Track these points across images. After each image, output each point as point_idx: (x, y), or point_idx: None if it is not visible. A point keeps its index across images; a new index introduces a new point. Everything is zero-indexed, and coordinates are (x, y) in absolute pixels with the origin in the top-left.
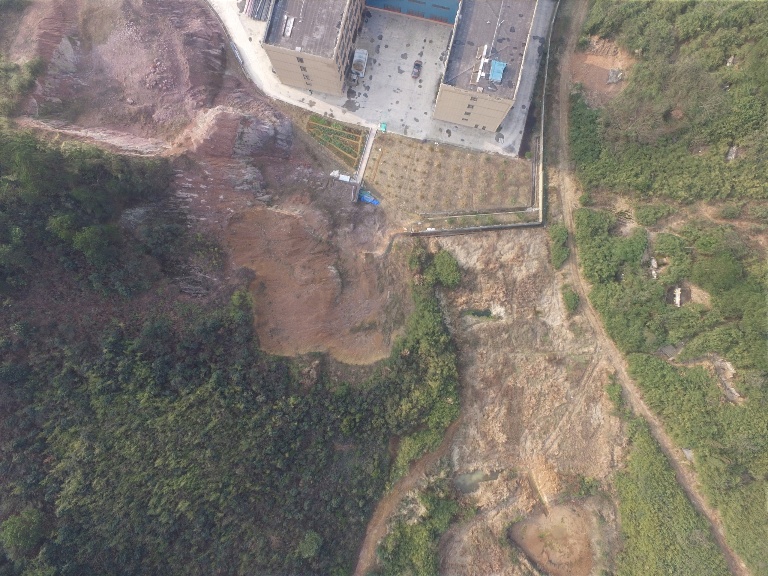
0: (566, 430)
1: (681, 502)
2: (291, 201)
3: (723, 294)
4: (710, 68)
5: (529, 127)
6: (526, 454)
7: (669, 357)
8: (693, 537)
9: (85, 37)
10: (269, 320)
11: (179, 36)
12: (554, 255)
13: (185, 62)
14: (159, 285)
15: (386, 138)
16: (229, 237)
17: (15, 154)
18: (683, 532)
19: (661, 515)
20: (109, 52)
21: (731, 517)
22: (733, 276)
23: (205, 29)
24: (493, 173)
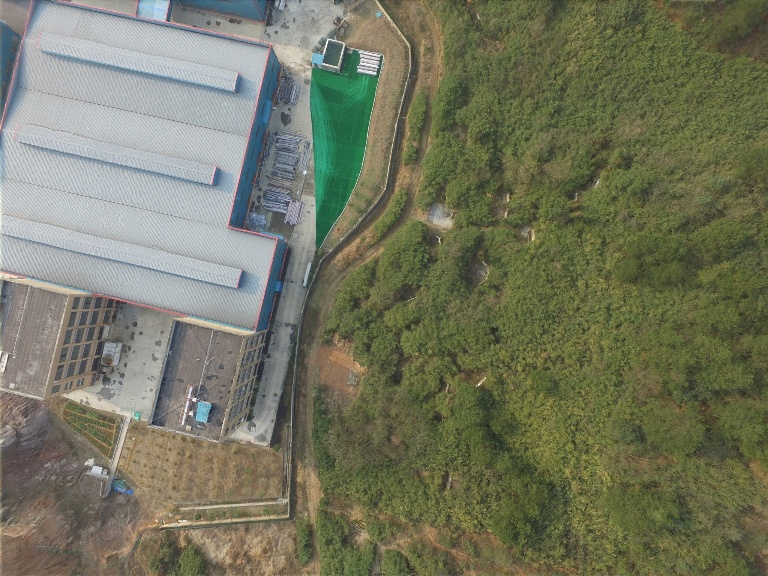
0: None
1: None
2: (32, 507)
3: None
4: (427, 395)
5: (280, 417)
6: None
7: None
8: None
9: None
10: None
11: None
12: (299, 553)
13: None
14: None
15: (140, 427)
16: None
17: None
18: None
19: None
20: None
21: None
22: None
23: None
24: (244, 464)
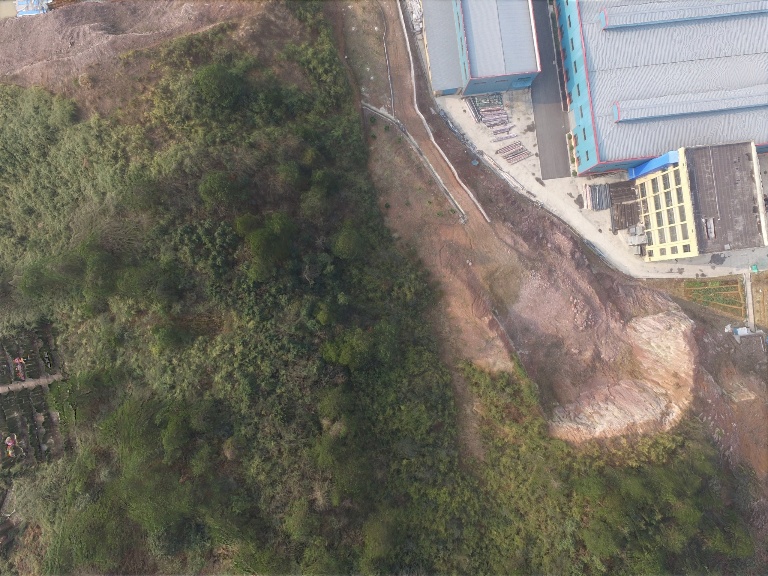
0: None
1: None
2: (725, 377)
3: None
4: None
5: None
6: None
7: None
8: None
9: (499, 303)
10: None
11: (570, 263)
12: None
13: (589, 287)
14: None
15: (762, 278)
16: None
17: (624, 483)
18: None
19: None
20: (526, 308)
21: None
22: None
23: None
24: None
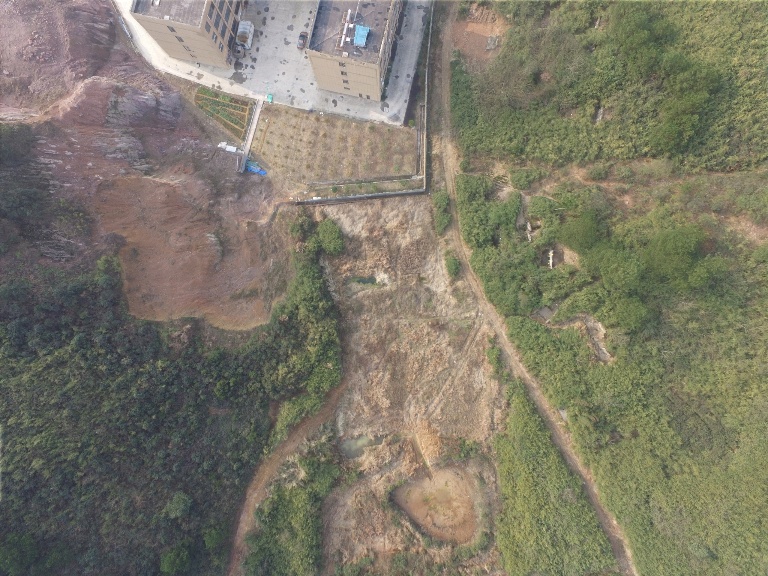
0: (449, 394)
1: (554, 462)
2: (173, 171)
3: (587, 253)
4: (577, 31)
5: (413, 96)
6: (410, 419)
7: (546, 320)
8: (566, 496)
9: None
10: (141, 286)
11: (60, 9)
12: (437, 221)
13: (65, 35)
14: (18, 249)
15: (273, 109)
16: (98, 204)
17: None
18: (556, 491)
19: (536, 475)
20: None
21: (602, 475)
22: (595, 235)
23: (90, 3)
24: (378, 142)
